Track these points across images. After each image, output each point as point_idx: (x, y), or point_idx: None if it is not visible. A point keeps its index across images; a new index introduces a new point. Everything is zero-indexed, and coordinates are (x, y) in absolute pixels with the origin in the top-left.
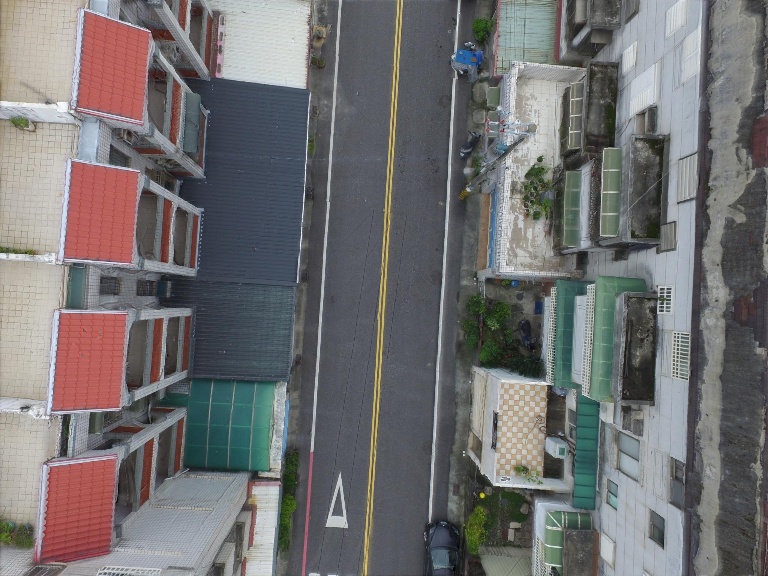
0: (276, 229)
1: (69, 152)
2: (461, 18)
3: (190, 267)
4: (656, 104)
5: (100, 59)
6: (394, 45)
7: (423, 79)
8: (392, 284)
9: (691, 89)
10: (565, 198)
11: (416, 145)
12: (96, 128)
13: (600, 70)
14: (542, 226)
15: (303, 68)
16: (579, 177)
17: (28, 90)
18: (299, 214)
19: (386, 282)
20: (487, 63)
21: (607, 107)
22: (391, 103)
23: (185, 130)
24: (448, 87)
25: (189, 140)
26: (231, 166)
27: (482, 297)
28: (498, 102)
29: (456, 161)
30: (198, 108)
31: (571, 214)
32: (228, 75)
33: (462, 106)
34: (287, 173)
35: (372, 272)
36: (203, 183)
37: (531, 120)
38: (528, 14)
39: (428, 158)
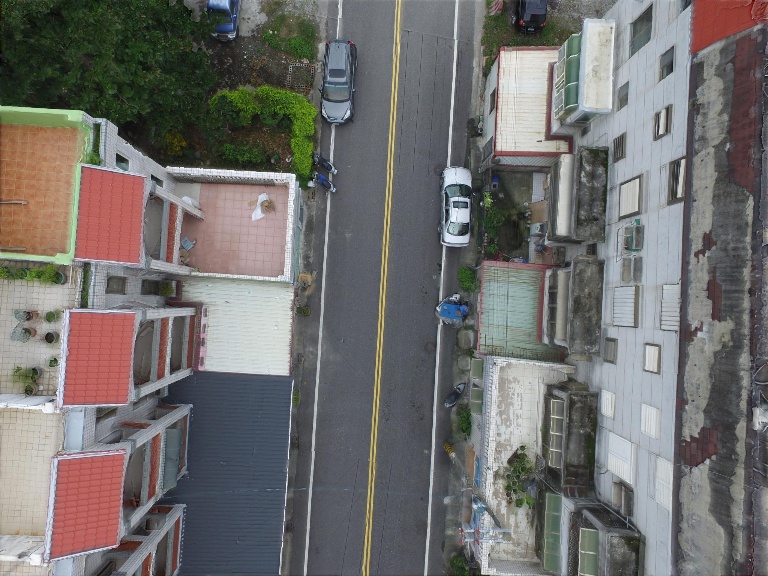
0: (258, 521)
1: (44, 571)
2: (446, 263)
3: (171, 575)
4: (632, 487)
5: (74, 501)
6: (379, 293)
7: (408, 326)
8: (377, 535)
9: (665, 517)
10: (546, 520)
11: (401, 393)
12: (70, 563)
13: (580, 399)
14: (525, 512)
15: (286, 355)
16: (559, 501)
17: (3, 508)
18: (282, 504)
19: (371, 534)
20: (472, 308)
21: (587, 437)
22: (376, 351)
23: (165, 469)
24: (433, 334)
25: (169, 477)
26: (214, 459)
27: (467, 557)
28: (481, 375)
29: (441, 408)
30: (178, 441)
31: (551, 538)
32: (211, 366)
33: (447, 352)
34: (270, 463)
35: (357, 522)
36: (185, 478)
37: (514, 404)
38: (511, 292)
39: (413, 405)
